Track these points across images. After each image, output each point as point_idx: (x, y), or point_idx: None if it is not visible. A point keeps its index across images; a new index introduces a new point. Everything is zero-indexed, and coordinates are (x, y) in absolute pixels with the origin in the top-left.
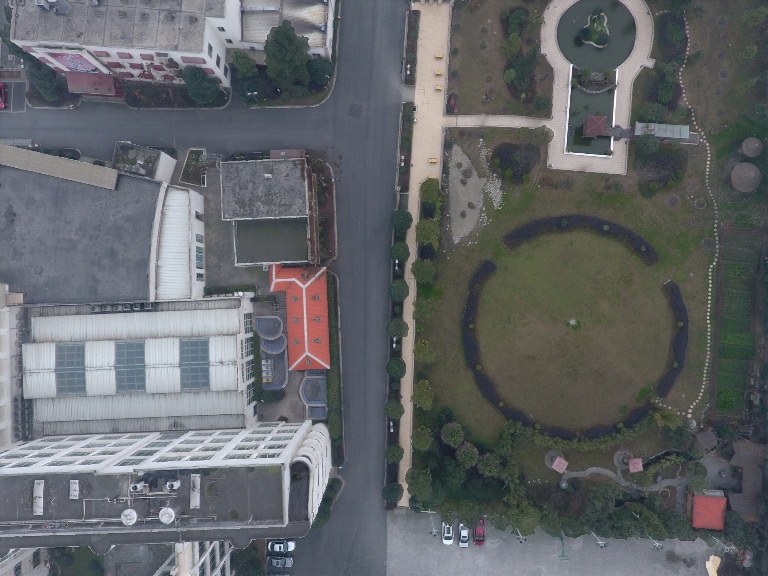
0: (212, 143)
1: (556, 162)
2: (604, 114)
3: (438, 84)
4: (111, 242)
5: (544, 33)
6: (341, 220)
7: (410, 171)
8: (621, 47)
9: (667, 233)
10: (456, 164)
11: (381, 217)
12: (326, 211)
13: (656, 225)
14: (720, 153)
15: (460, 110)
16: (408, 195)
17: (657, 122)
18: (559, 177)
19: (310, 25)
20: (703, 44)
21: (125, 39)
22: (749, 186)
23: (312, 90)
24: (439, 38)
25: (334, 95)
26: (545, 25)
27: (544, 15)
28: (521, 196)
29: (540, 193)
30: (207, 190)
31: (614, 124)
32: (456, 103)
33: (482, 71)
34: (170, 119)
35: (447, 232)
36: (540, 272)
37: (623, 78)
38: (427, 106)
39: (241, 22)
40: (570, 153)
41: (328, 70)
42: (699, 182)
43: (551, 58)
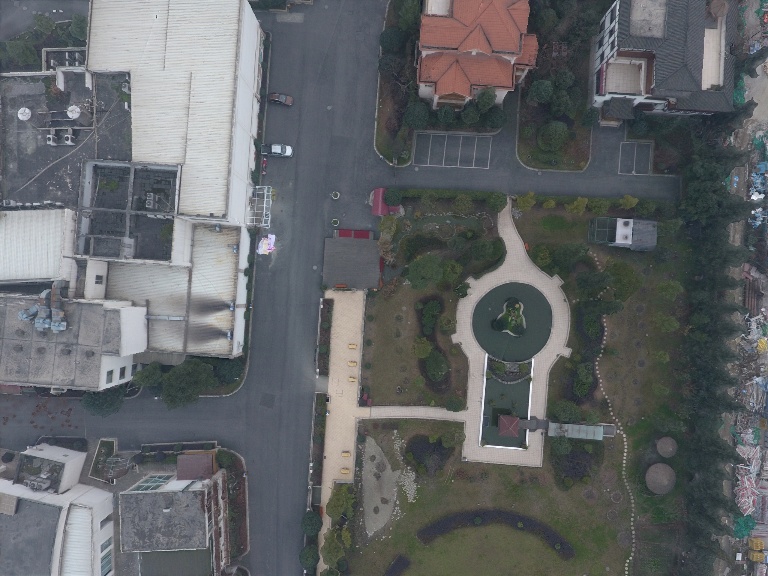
0: (123, 433)
1: (471, 454)
2: (520, 404)
3: (352, 374)
4: (11, 566)
5: (459, 321)
6: (253, 513)
7: (323, 464)
8: (537, 335)
9: (583, 526)
10: (369, 457)
11: (294, 510)
12: (237, 506)
13: (572, 518)
14: (637, 445)
15: (374, 400)
16: (321, 488)
17: (571, 422)
18: (474, 470)
19: (217, 331)
20: (620, 332)
21: (21, 373)
22: (663, 490)
23: (223, 382)
24: (353, 326)
25: (247, 384)
26: (460, 313)
27: (459, 303)
28: (435, 489)
29: (455, 486)
30: (116, 487)
31: (529, 416)
32: (370, 393)
33: (396, 360)
34: (81, 408)
35: (360, 526)
36: (454, 567)
37: (539, 367)
38: (340, 396)
39: (147, 328)
40: (485, 446)
41: (236, 374)
42: (616, 474)
43: (466, 347)
